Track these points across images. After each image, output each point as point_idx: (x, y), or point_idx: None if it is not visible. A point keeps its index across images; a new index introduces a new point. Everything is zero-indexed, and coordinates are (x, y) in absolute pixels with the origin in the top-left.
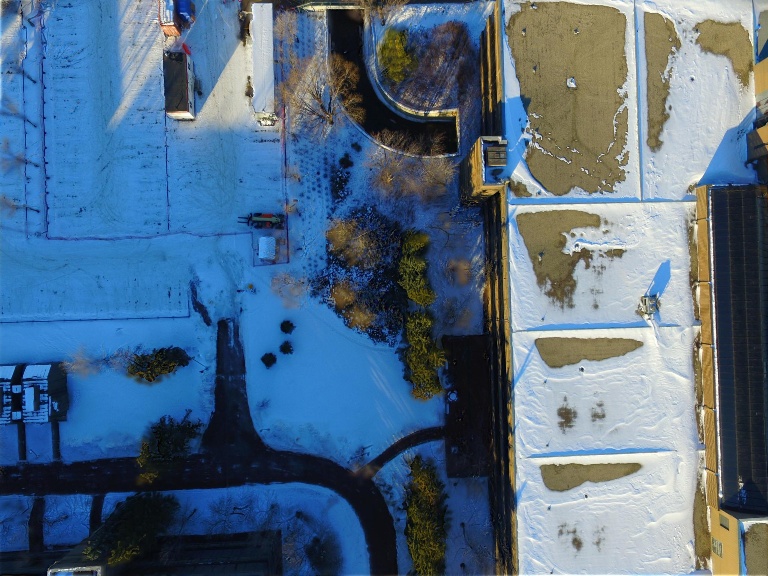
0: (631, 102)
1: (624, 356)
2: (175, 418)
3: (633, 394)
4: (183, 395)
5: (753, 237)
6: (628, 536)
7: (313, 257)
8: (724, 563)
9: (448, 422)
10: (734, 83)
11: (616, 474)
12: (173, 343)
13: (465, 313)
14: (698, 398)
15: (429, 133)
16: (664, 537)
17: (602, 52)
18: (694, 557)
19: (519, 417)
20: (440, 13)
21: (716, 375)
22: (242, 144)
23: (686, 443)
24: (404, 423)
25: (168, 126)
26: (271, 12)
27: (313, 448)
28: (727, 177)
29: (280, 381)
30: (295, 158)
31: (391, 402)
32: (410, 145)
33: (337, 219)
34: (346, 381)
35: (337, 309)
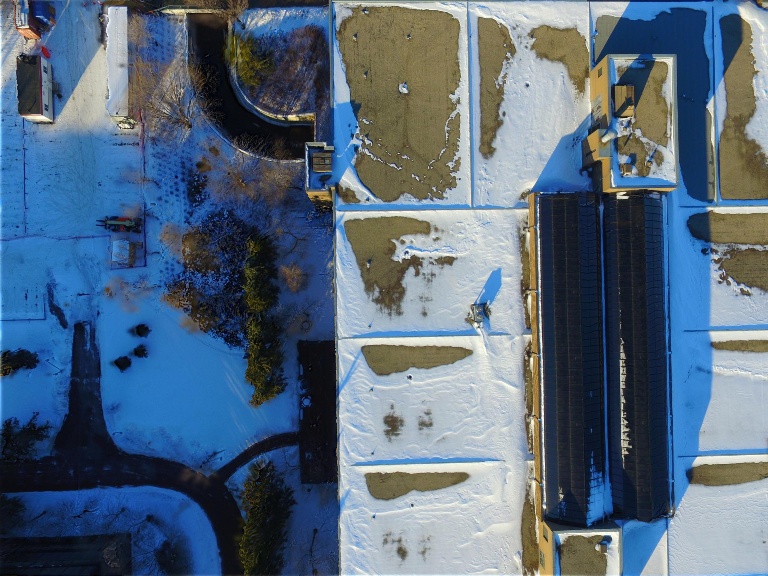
0: (463, 108)
1: (453, 364)
2: (21, 420)
3: (462, 403)
4: (36, 397)
5: (574, 246)
6: (454, 546)
7: (170, 261)
8: (545, 575)
9: (302, 428)
10: (570, 89)
11: (443, 483)
12: (23, 345)
13: (320, 318)
14: (528, 408)
15: (290, 137)
16: (491, 547)
17: (435, 57)
18: (521, 568)
19: (344, 425)
20: (299, 17)
21: (542, 385)
22: (101, 147)
23: (514, 453)
24: (258, 428)
25: (26, 129)
26: (126, 15)
27: (166, 452)
28: (559, 184)
29: (134, 384)
30: (154, 162)
31: (245, 407)
32: (268, 149)
33: (195, 223)
34: (200, 385)
35: (193, 313)
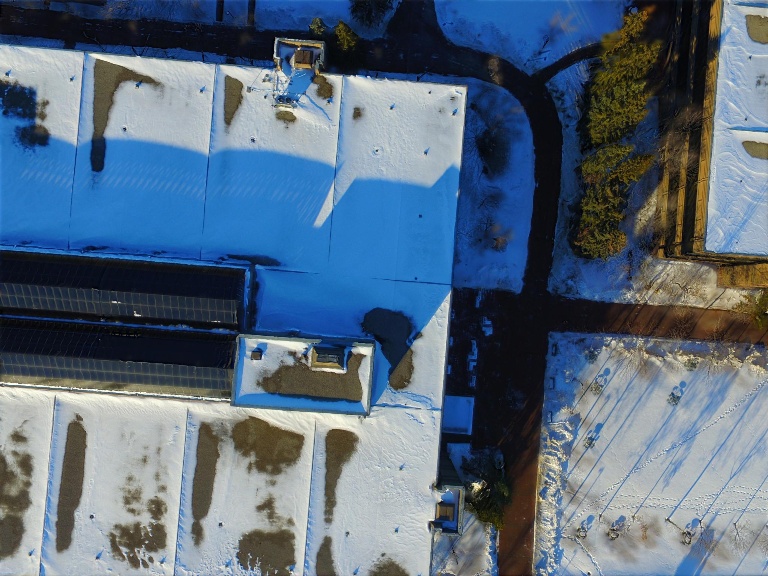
0: None
1: None
2: None
3: None
4: None
5: None
6: None
7: None
8: None
9: None
10: None
11: None
12: None
13: None
14: None
15: None
16: None
17: None
18: None
19: None
20: None
21: None
22: None
23: None
24: (583, 33)
25: None
26: None
27: (492, 47)
28: None
29: None
30: None
31: (572, 13)
32: None
33: None
34: None
35: None
